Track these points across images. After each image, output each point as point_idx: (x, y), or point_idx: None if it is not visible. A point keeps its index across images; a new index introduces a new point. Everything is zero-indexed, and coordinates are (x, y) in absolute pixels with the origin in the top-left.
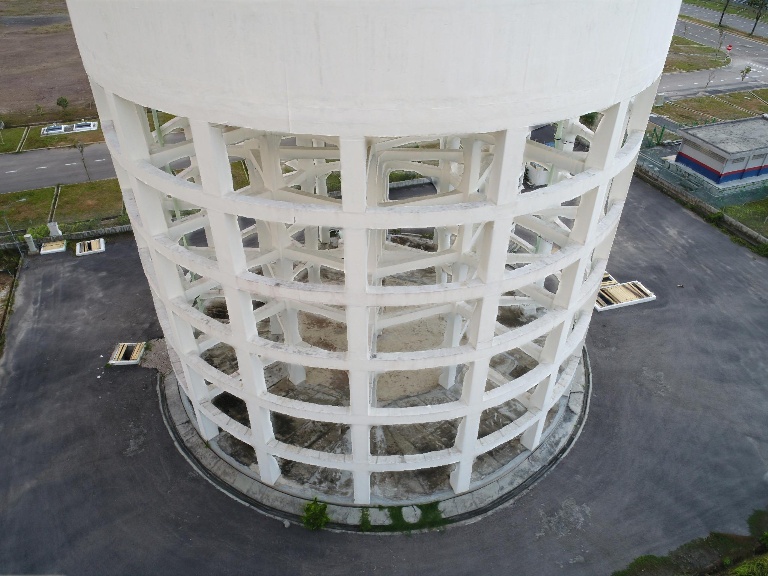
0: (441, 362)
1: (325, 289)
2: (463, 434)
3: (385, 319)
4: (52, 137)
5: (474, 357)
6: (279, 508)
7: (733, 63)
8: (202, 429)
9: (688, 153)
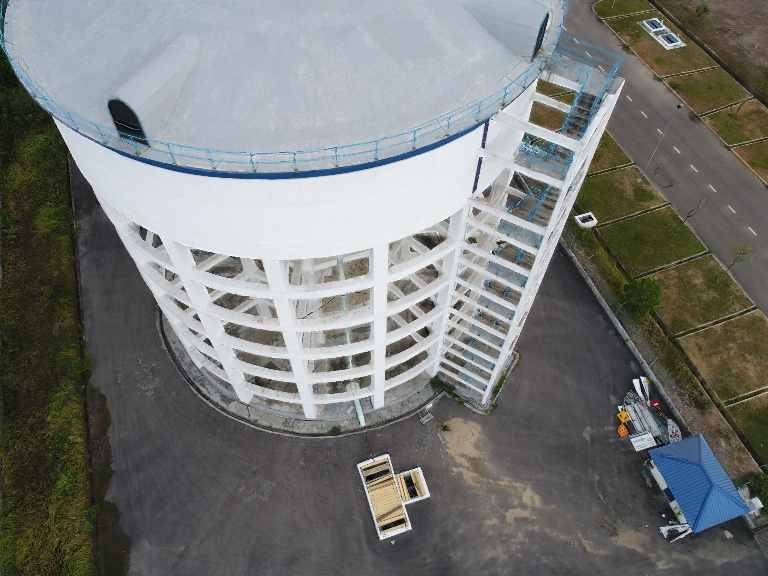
0: None
1: None
2: None
3: None
4: (637, 29)
5: None
6: None
7: None
8: None
9: None
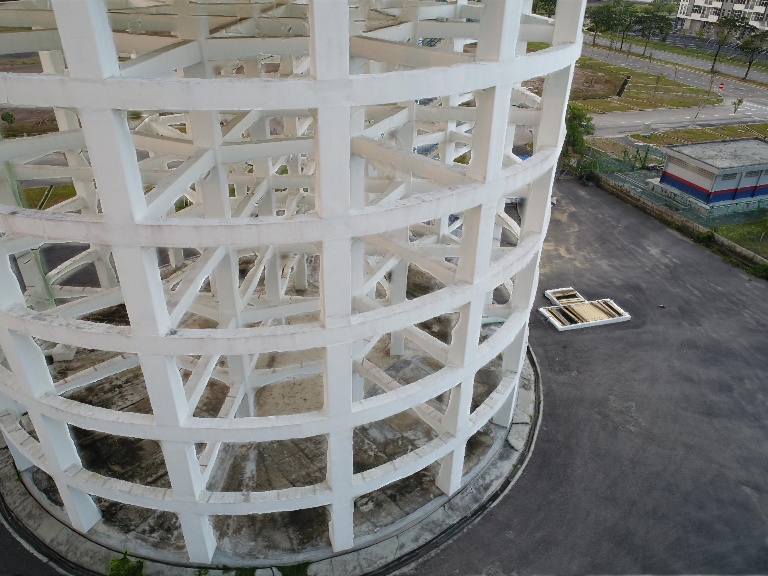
0: (273, 344)
1: (78, 218)
2: (329, 462)
3: (253, 310)
4: None
5: (324, 340)
6: (87, 566)
7: (726, 102)
8: (12, 455)
9: (673, 172)
